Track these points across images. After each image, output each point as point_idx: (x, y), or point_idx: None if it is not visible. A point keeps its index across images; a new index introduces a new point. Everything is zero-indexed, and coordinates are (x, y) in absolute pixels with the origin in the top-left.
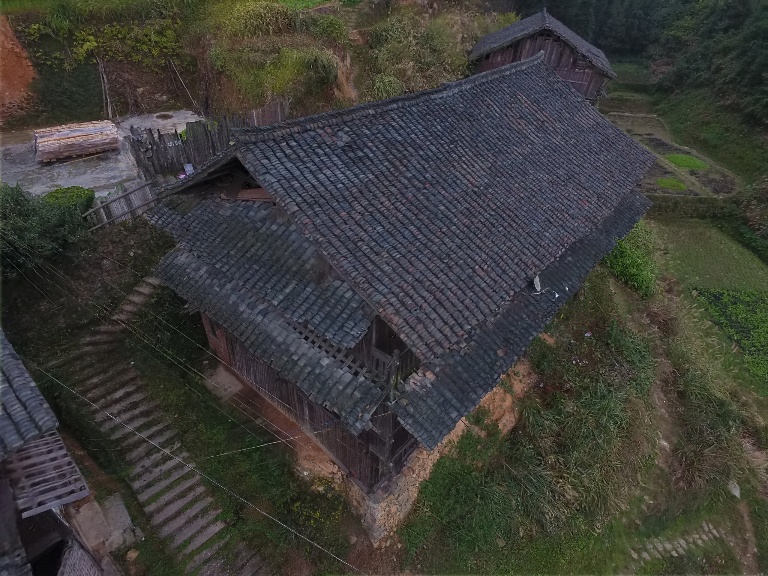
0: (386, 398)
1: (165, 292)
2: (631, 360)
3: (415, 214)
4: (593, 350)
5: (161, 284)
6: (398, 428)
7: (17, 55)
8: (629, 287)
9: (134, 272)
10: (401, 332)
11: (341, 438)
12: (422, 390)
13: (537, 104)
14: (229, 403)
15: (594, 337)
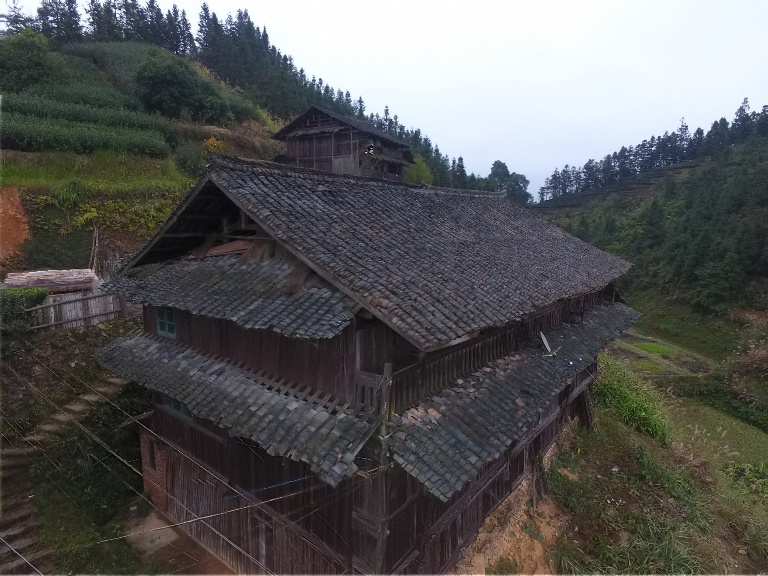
0: (376, 444)
1: (101, 409)
2: (677, 495)
3: (401, 243)
4: (627, 486)
5: (99, 400)
6: (394, 514)
7: (17, 221)
8: (643, 433)
9: (70, 387)
10: (393, 315)
11: (311, 574)
12: (425, 426)
13: (508, 216)
14: (154, 558)
15: (623, 472)
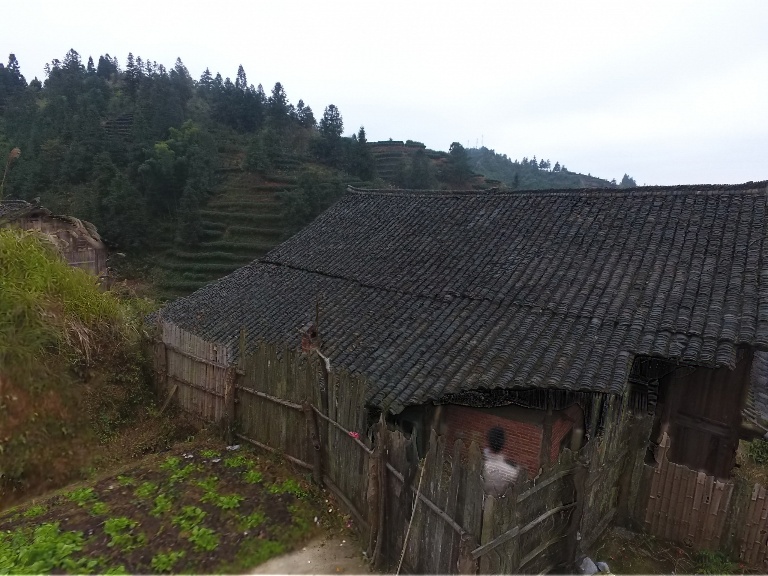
0: None
1: None
2: None
3: None
4: None
5: None
6: None
7: None
8: None
9: None
10: None
11: None
12: None
13: None
14: None
15: None
